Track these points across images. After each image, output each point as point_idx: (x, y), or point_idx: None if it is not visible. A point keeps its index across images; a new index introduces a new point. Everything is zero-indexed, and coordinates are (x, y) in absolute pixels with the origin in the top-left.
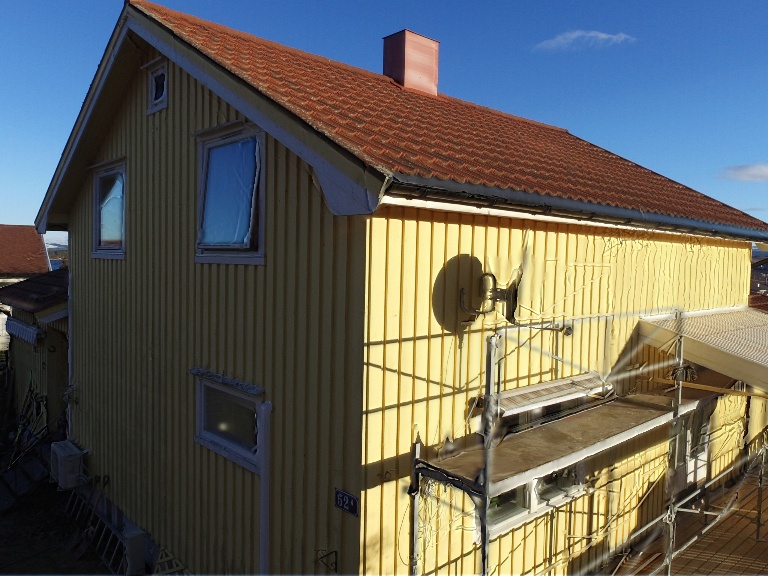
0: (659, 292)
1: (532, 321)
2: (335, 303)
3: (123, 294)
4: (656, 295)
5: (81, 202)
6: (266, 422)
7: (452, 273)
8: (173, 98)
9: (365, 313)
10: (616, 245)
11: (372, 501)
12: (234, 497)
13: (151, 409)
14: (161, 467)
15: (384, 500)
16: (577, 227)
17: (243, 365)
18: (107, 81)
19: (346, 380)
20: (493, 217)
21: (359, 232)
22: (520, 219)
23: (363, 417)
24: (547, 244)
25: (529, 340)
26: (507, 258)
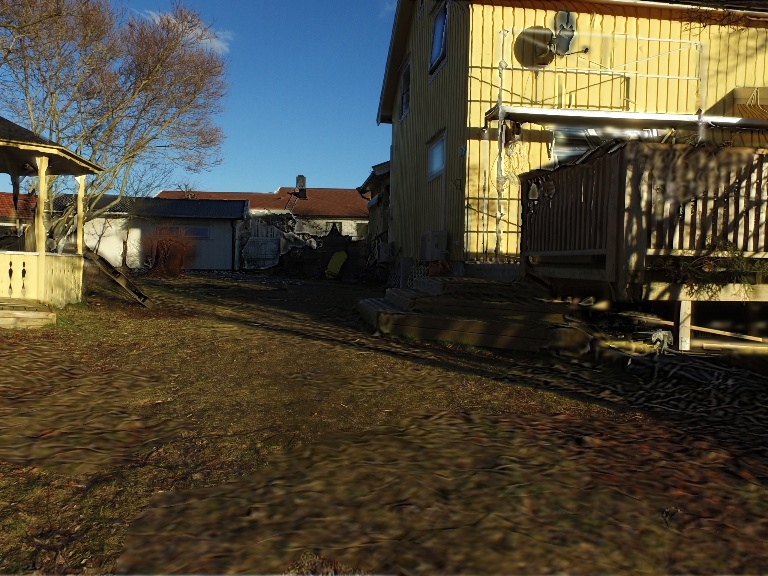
0: (765, 69)
1: (602, 72)
2: (463, 57)
3: (408, 132)
4: (762, 72)
5: (396, 96)
6: (445, 141)
7: (529, 36)
8: (425, 2)
9: (470, 52)
10: (698, 28)
11: (473, 146)
12: (437, 197)
13: (415, 186)
14: (417, 214)
15: (481, 148)
16: (646, 13)
17: (441, 122)
18: (400, 8)
19: (465, 91)
20: (557, 2)
21: (467, 12)
22: (579, 3)
23: (468, 103)
24: (616, 24)
25: (600, 84)
26: (575, 30)
